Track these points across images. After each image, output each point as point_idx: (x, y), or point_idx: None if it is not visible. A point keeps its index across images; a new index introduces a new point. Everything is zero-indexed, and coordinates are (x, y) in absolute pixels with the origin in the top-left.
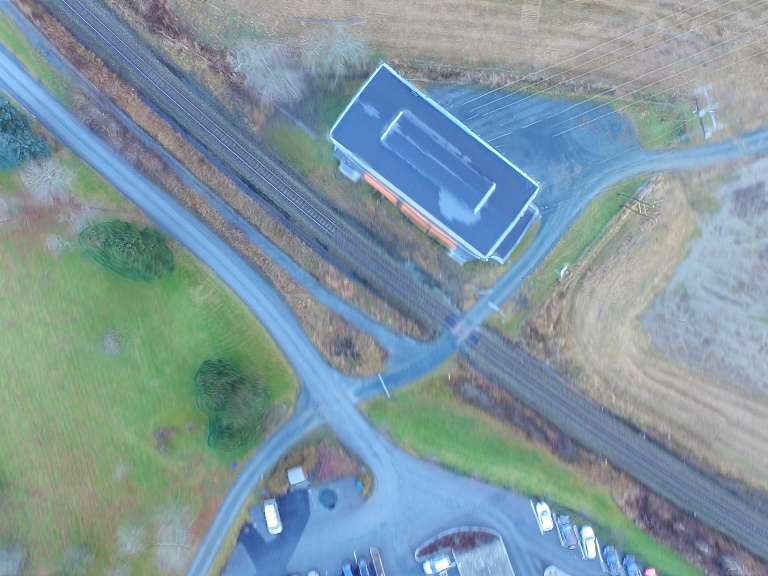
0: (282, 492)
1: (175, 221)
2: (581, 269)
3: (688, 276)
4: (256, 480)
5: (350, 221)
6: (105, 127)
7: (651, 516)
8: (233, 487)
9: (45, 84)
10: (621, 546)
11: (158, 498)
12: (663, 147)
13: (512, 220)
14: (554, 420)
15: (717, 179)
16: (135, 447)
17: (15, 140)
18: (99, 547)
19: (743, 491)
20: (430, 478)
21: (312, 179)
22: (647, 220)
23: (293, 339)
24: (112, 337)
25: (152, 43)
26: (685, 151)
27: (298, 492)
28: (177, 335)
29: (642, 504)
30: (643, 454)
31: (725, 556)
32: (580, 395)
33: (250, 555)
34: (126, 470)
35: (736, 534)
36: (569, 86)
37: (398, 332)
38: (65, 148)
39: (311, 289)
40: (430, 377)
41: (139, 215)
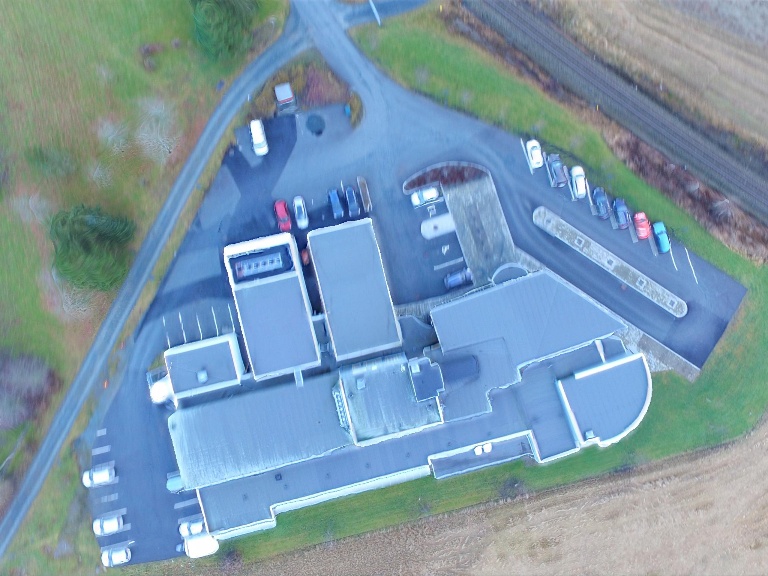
0: (269, 115)
1: None
2: None
3: None
4: (242, 101)
5: None
6: None
7: (642, 157)
8: (219, 107)
9: None
10: (611, 189)
11: (142, 113)
12: None
13: None
14: (546, 65)
15: None
16: (119, 63)
17: None
18: (80, 163)
19: (734, 146)
20: (419, 110)
21: None
22: None
23: None
24: None
25: None
26: None
27: (285, 117)
28: None
29: (633, 147)
30: (635, 103)
31: (715, 202)
32: (572, 43)
33: (235, 179)
34: (110, 85)
35: (726, 188)
36: None
37: None
38: None
39: None
40: (421, 11)
41: None
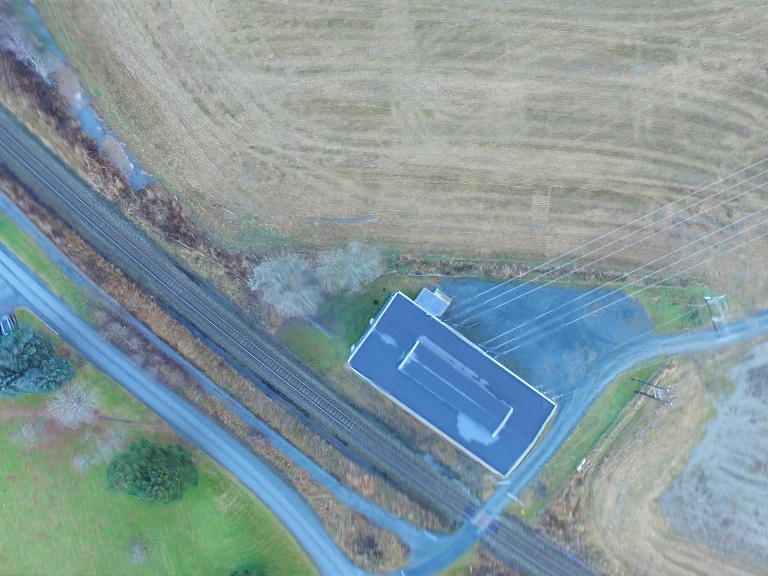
0: None
1: (197, 430)
2: (598, 455)
3: (705, 457)
4: None
5: (368, 417)
6: (126, 341)
7: None
8: None
9: (67, 301)
10: None
11: None
12: (676, 330)
13: (530, 442)
14: None
15: (731, 360)
16: None
17: (41, 377)
18: None
19: None
20: None
21: (330, 377)
22: (662, 404)
23: (316, 540)
24: (139, 546)
25: (169, 251)
26: (698, 334)
27: None
28: (203, 540)
29: None
30: None
31: None
32: None
33: None
34: None
35: None
36: (581, 274)
37: (419, 527)
38: (88, 363)
39: (332, 489)
40: (452, 569)
41: (162, 425)
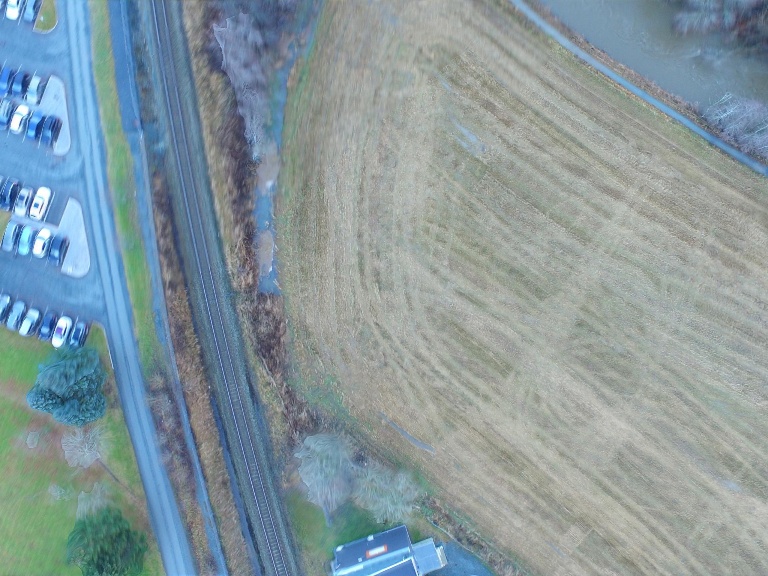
0: None
1: (167, 526)
2: None
3: None
4: None
5: None
6: (164, 413)
7: None
8: None
9: (140, 347)
10: None
11: None
12: None
13: None
14: None
15: None
16: None
17: (76, 415)
18: None
19: None
20: None
21: (304, 555)
22: None
23: None
24: None
25: (250, 360)
26: None
27: None
28: None
29: None
30: None
31: None
32: None
33: None
34: None
35: None
36: None
37: None
38: (120, 409)
39: None
40: None
41: (141, 502)
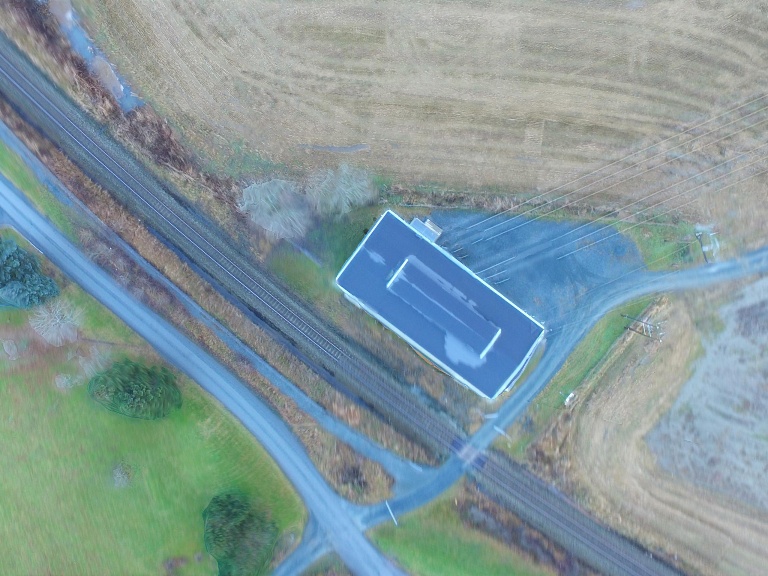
0: None
1: (182, 354)
2: (586, 391)
3: (693, 396)
4: None
5: (356, 347)
6: (112, 262)
7: None
8: None
9: (52, 220)
10: None
11: None
12: (667, 267)
13: (518, 364)
14: (561, 541)
15: (721, 298)
16: None
17: (24, 289)
18: None
19: None
20: None
21: (318, 306)
22: (651, 341)
23: (300, 468)
24: (121, 470)
25: (158, 174)
26: (689, 271)
27: None
28: (185, 466)
29: None
30: (650, 574)
31: None
32: (586, 515)
33: None
34: None
35: None
36: (572, 209)
37: (405, 458)
38: (73, 283)
39: (318, 418)
40: (437, 502)
41: (147, 348)
